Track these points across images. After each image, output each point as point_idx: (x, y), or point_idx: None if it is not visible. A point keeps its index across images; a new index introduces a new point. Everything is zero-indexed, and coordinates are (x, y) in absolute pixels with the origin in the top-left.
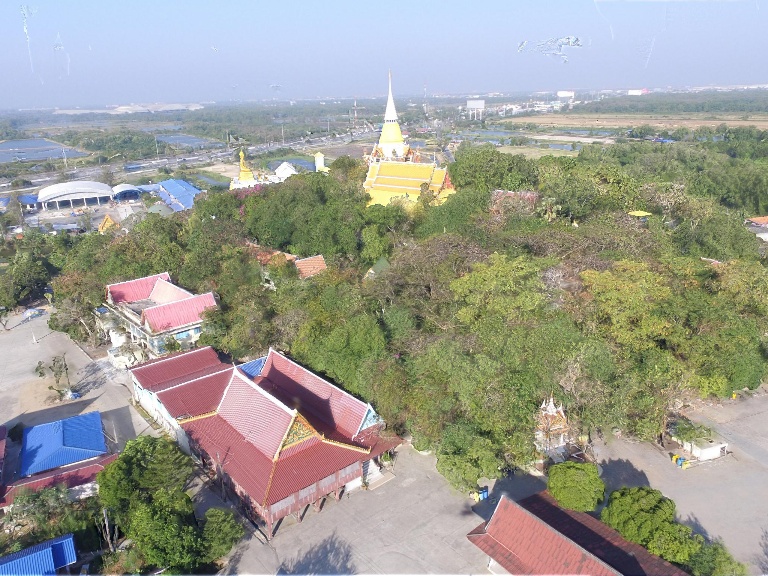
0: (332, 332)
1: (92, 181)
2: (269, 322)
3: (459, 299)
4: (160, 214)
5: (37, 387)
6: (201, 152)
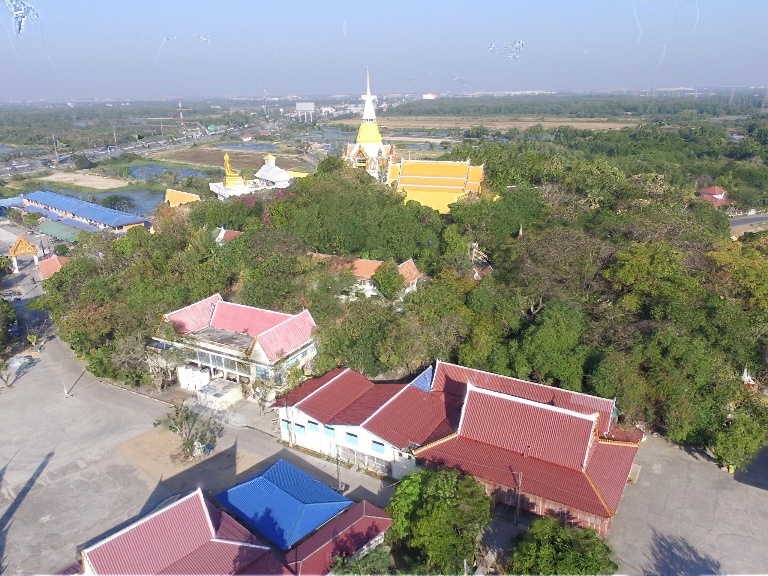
0: (539, 333)
1: None
2: (423, 333)
3: (619, 288)
4: (67, 232)
5: (140, 447)
6: (20, 160)
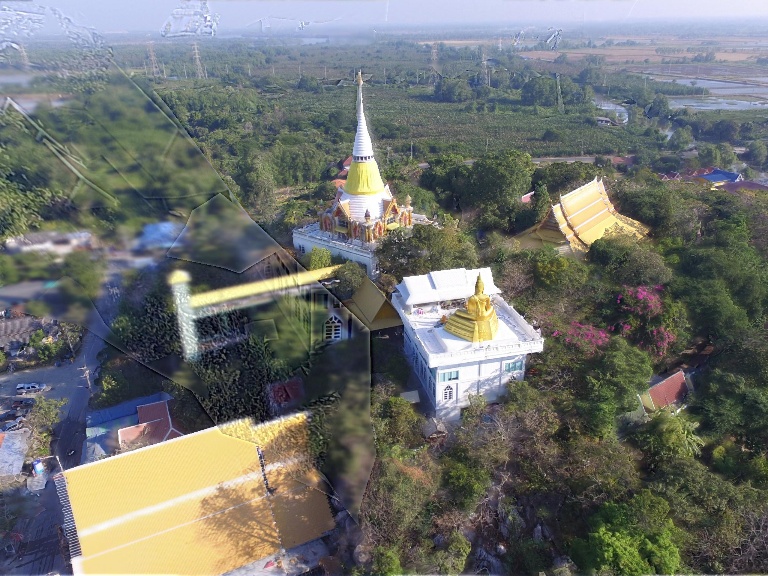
0: None
1: None
2: None
3: None
4: None
5: None
6: None
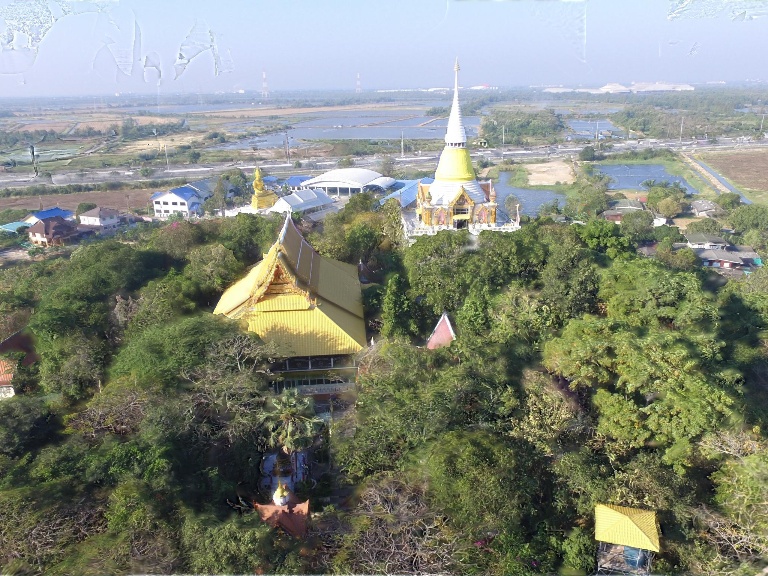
0: None
1: (369, 170)
2: None
3: None
4: None
5: None
6: (567, 144)
